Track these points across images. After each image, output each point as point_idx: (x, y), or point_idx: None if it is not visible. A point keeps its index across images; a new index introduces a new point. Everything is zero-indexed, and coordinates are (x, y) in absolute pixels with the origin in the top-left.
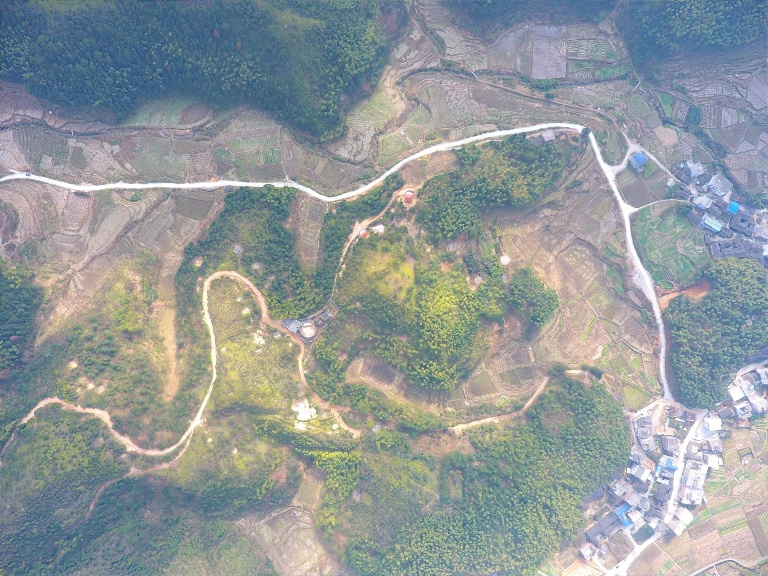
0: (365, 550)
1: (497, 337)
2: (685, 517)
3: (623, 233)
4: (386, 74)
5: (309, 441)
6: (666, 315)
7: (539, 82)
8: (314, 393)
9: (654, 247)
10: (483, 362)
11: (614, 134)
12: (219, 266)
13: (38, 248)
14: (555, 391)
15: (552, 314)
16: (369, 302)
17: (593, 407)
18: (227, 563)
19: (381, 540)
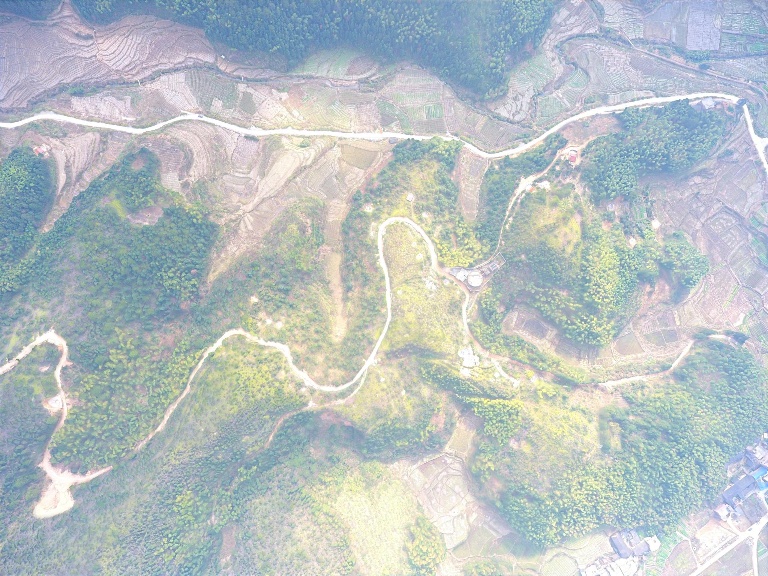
0: (523, 496)
1: (646, 298)
2: None
3: None
4: (546, 37)
5: (472, 387)
6: None
7: (694, 53)
8: (475, 342)
9: None
10: (631, 322)
11: (765, 107)
12: (393, 212)
13: (209, 188)
14: (702, 353)
15: None
16: (536, 255)
17: (745, 369)
18: (386, 503)
19: (540, 487)
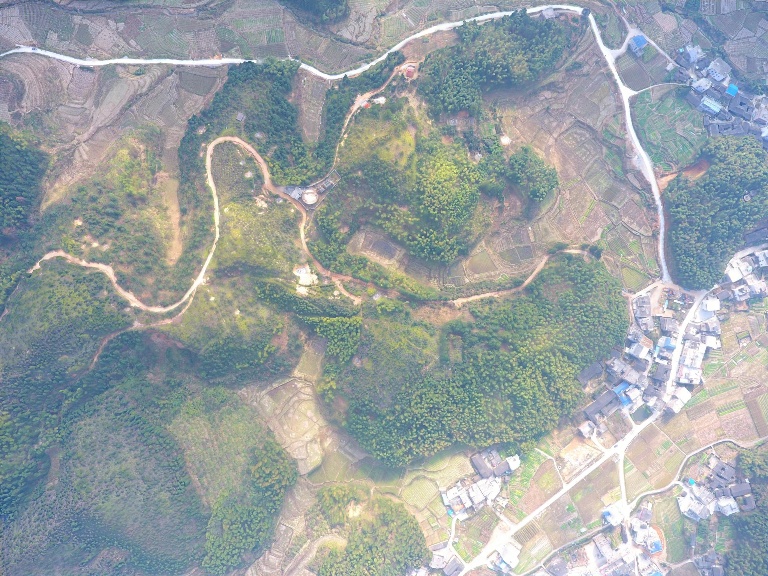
0: (365, 413)
1: (497, 215)
2: (683, 395)
3: (622, 115)
4: None
5: (310, 306)
6: (665, 194)
7: None
8: (315, 261)
9: (653, 128)
10: (483, 240)
11: (614, 18)
12: (222, 132)
13: (44, 119)
14: (554, 267)
15: (552, 195)
16: (370, 170)
17: (592, 277)
18: (229, 427)
19: (381, 403)
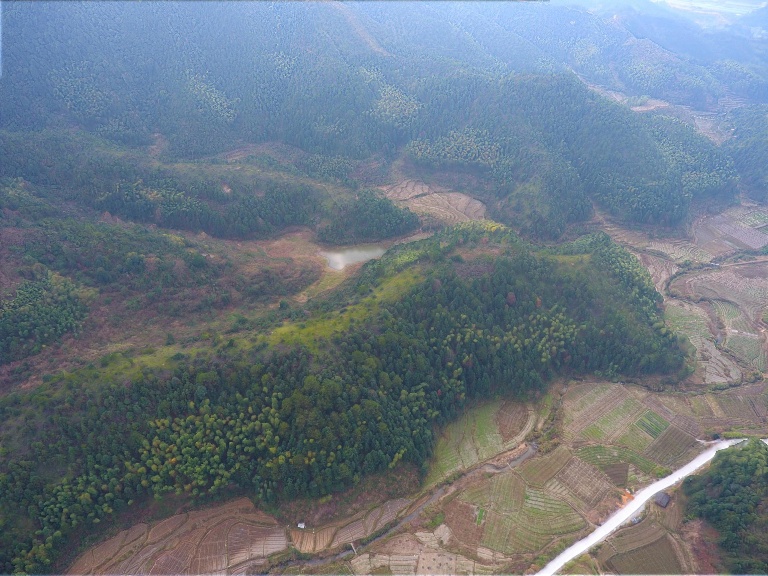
0: None
1: None
2: None
3: None
4: None
5: None
6: None
7: (765, 248)
8: None
9: None
10: None
11: None
12: None
13: None
14: None
15: None
16: None
17: None
18: None
19: None
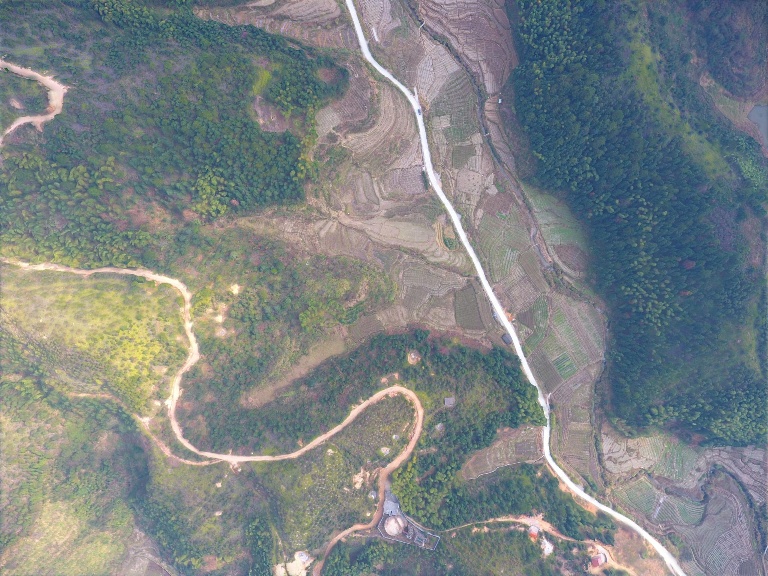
0: None
1: None
2: None
3: None
4: (719, 448)
5: None
6: None
7: None
8: (323, 559)
9: None
10: None
11: None
12: (422, 392)
13: (344, 164)
14: None
15: None
16: None
17: None
18: (86, 552)
19: None
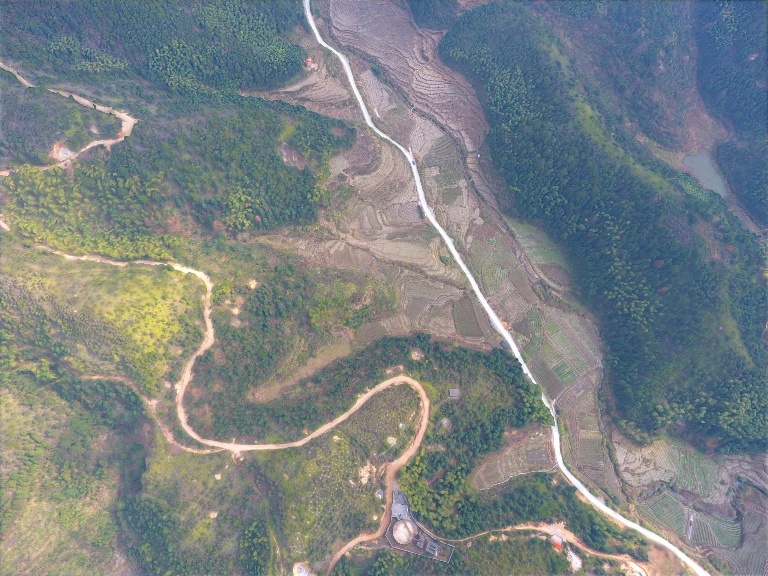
0: None
1: None
2: None
3: None
4: (738, 458)
5: None
6: None
7: None
8: None
9: None
10: None
11: None
12: (426, 382)
13: (352, 199)
14: None
15: None
16: None
17: None
18: (58, 575)
19: None
